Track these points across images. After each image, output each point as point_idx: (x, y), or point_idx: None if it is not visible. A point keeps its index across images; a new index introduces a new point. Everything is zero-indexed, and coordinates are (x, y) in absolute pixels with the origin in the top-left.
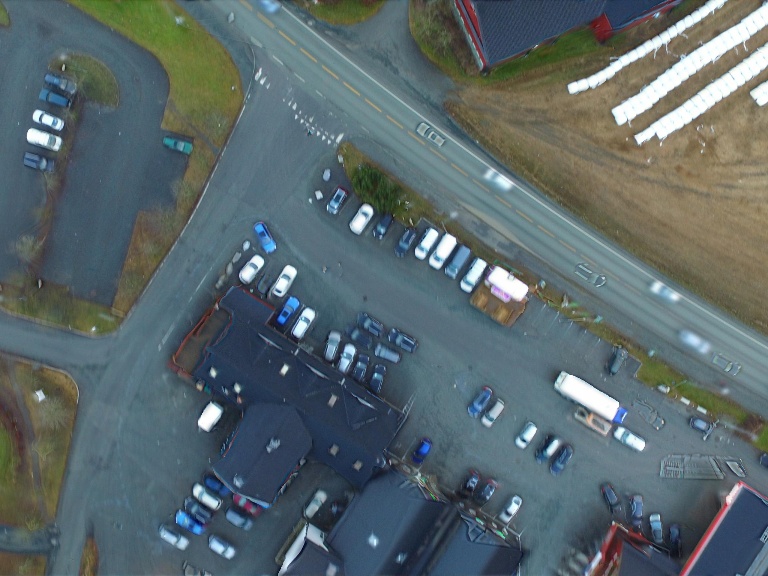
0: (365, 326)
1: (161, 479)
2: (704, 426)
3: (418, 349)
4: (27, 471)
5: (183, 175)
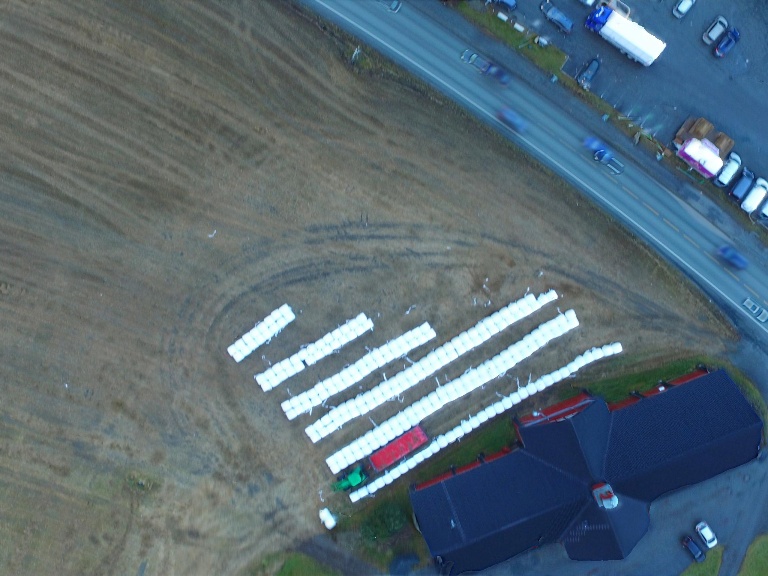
0: None
1: None
2: None
3: None
4: None
5: None
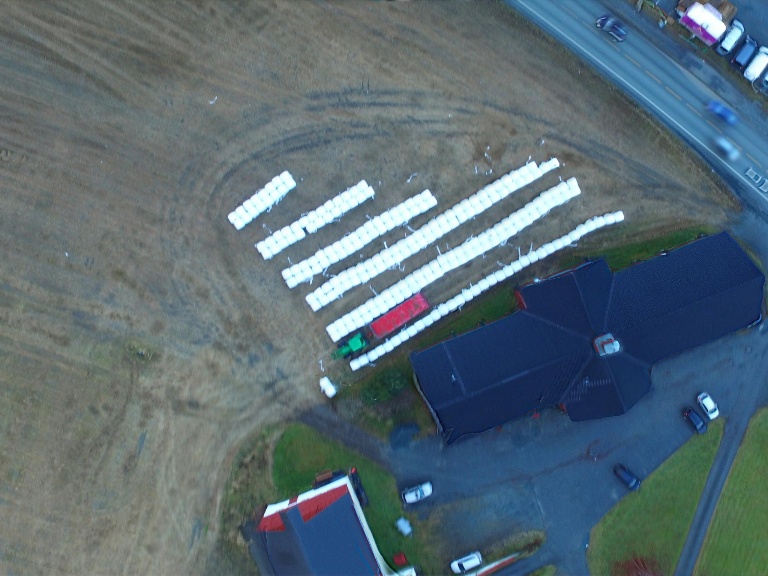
0: None
1: None
2: None
3: None
4: None
5: None
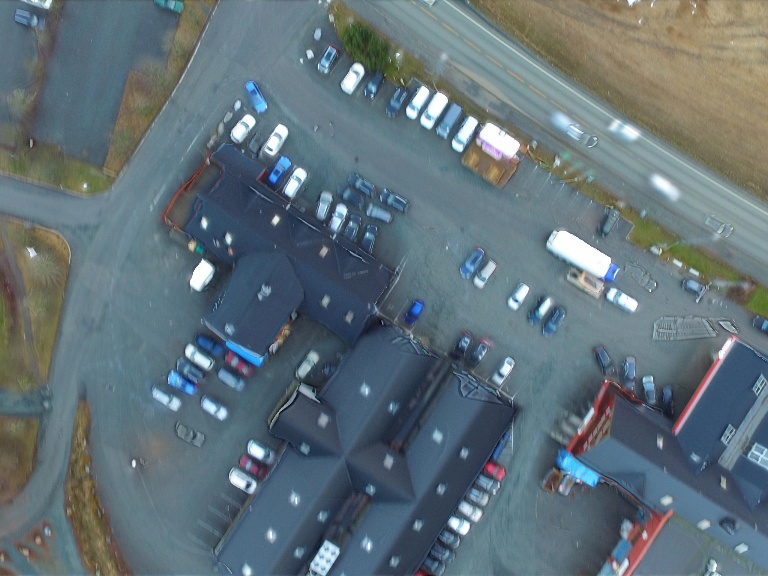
0: (357, 185)
1: (153, 340)
2: (696, 287)
3: (410, 211)
4: (19, 332)
5: (174, 34)
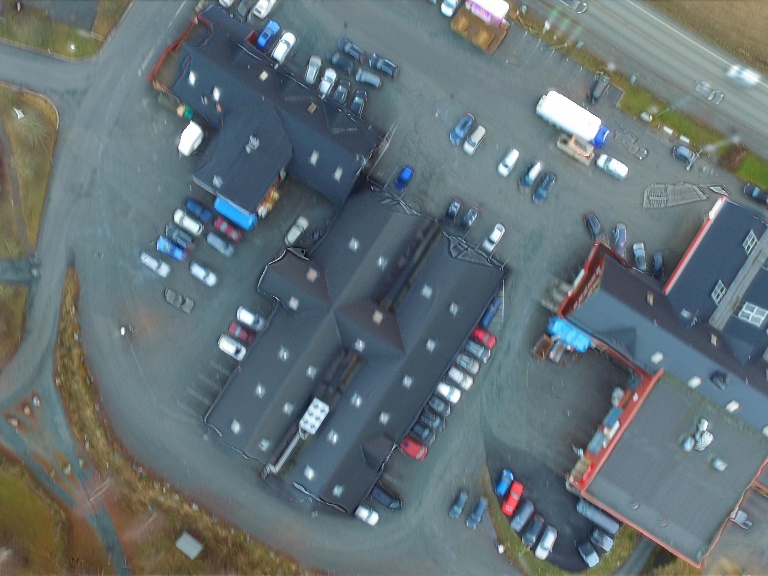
0: (346, 50)
1: (142, 206)
2: (687, 153)
3: (399, 77)
4: (7, 198)
5: None
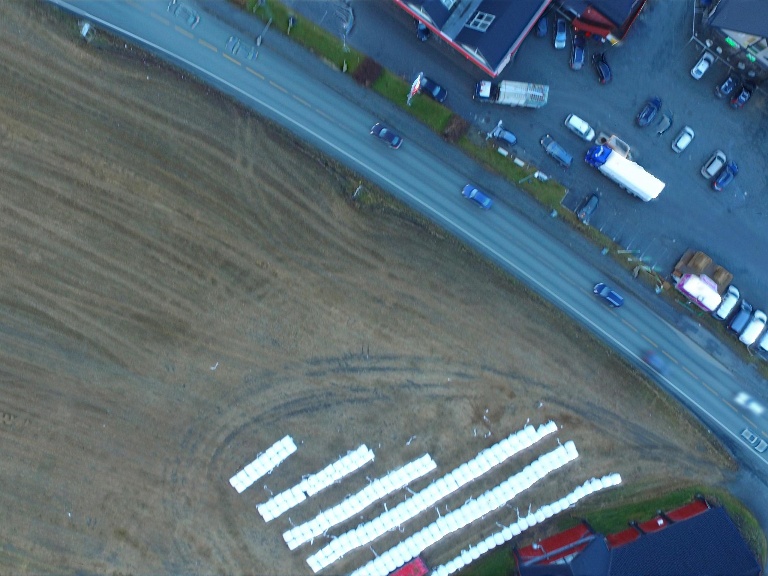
0: None
1: None
2: (507, 135)
3: None
4: None
5: None
